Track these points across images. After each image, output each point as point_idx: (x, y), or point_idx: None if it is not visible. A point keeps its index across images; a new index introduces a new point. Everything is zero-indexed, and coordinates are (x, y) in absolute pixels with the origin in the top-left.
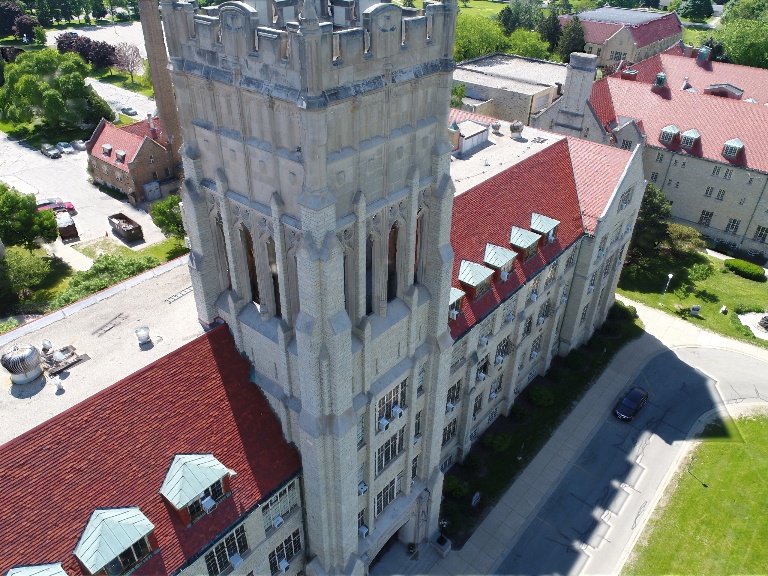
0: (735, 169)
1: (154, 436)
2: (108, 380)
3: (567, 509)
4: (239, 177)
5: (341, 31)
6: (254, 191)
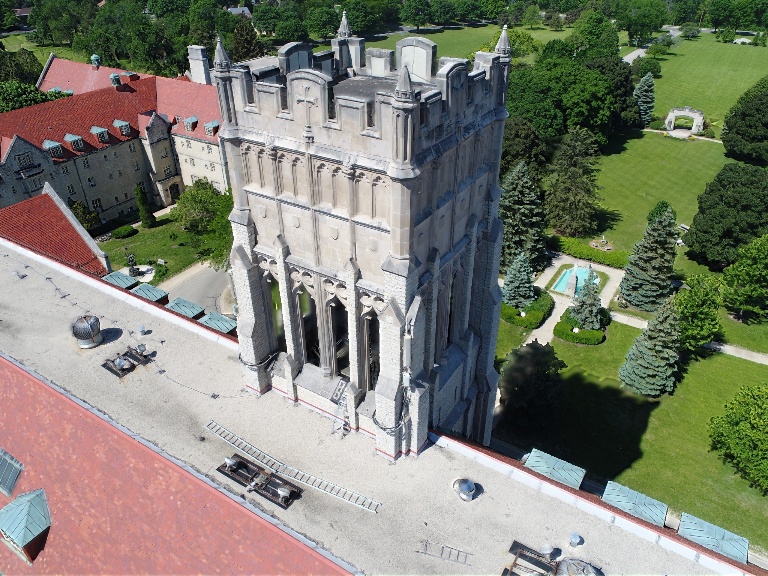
0: None
1: None
2: (542, 500)
3: None
4: (443, 239)
5: None
6: None
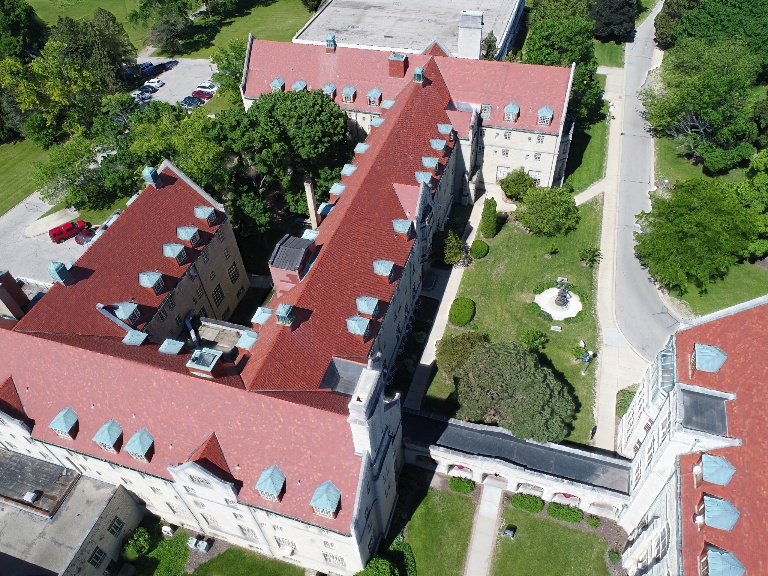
0: None
1: None
2: None
3: None
4: None
5: None
6: None
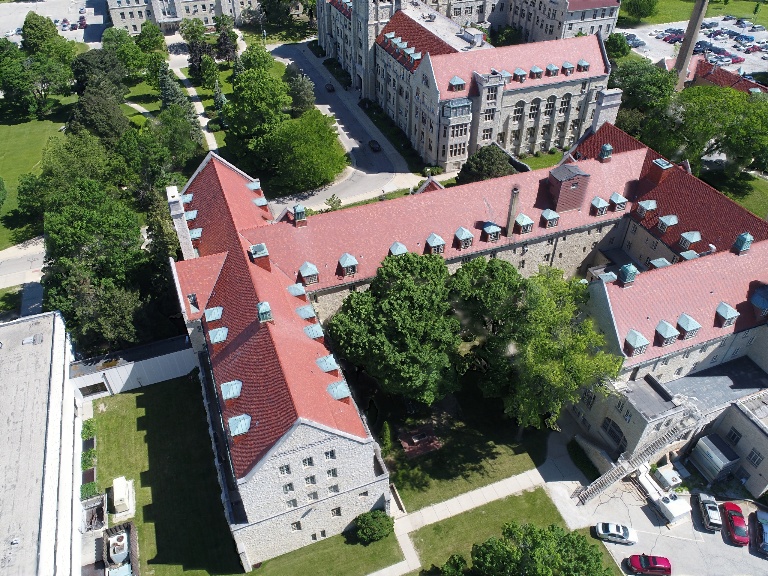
0: None
1: None
2: None
3: (351, 121)
4: None
5: None
6: None
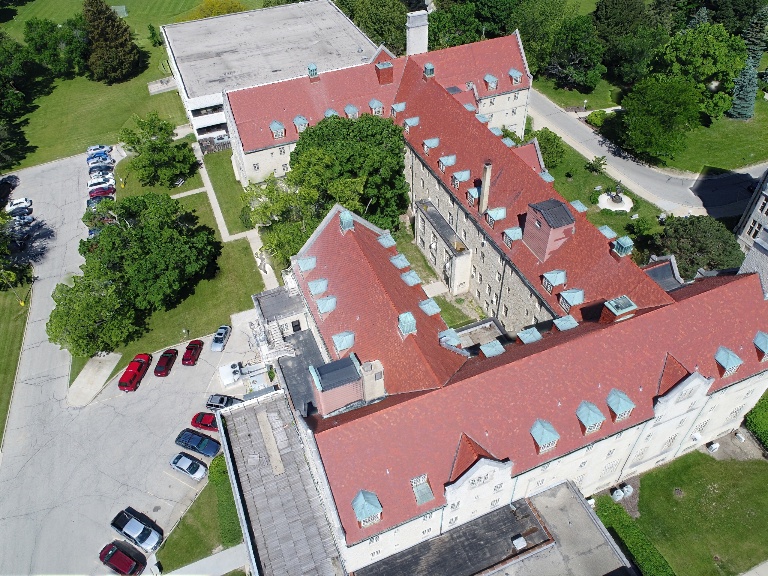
0: None
1: None
2: None
3: None
4: None
5: None
6: None
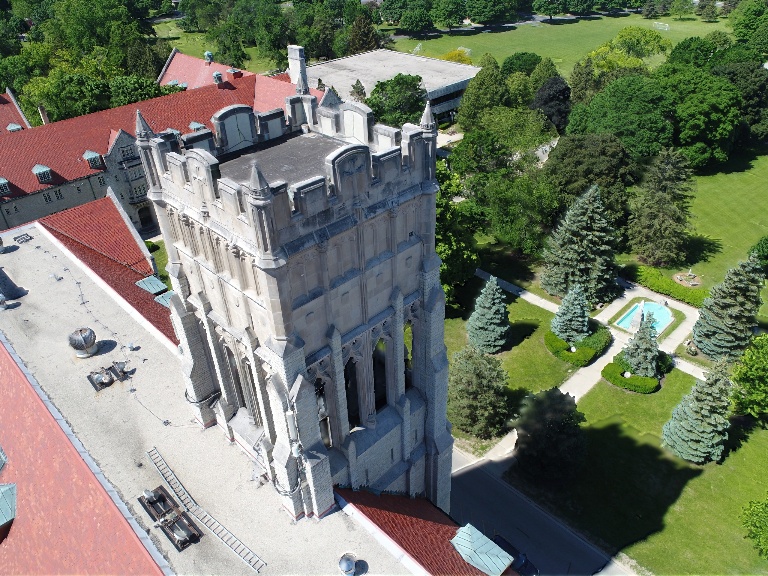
0: (61, 188)
1: (460, 568)
2: None
3: None
4: (351, 314)
5: (394, 129)
6: (368, 311)
